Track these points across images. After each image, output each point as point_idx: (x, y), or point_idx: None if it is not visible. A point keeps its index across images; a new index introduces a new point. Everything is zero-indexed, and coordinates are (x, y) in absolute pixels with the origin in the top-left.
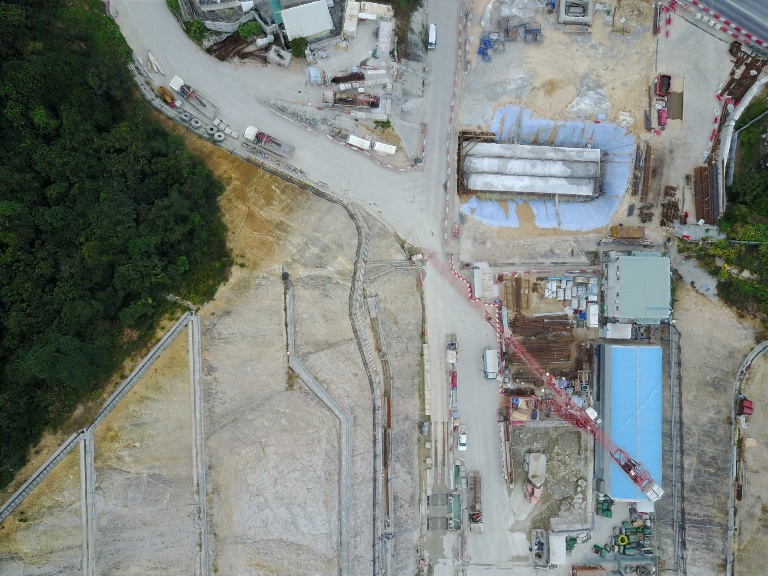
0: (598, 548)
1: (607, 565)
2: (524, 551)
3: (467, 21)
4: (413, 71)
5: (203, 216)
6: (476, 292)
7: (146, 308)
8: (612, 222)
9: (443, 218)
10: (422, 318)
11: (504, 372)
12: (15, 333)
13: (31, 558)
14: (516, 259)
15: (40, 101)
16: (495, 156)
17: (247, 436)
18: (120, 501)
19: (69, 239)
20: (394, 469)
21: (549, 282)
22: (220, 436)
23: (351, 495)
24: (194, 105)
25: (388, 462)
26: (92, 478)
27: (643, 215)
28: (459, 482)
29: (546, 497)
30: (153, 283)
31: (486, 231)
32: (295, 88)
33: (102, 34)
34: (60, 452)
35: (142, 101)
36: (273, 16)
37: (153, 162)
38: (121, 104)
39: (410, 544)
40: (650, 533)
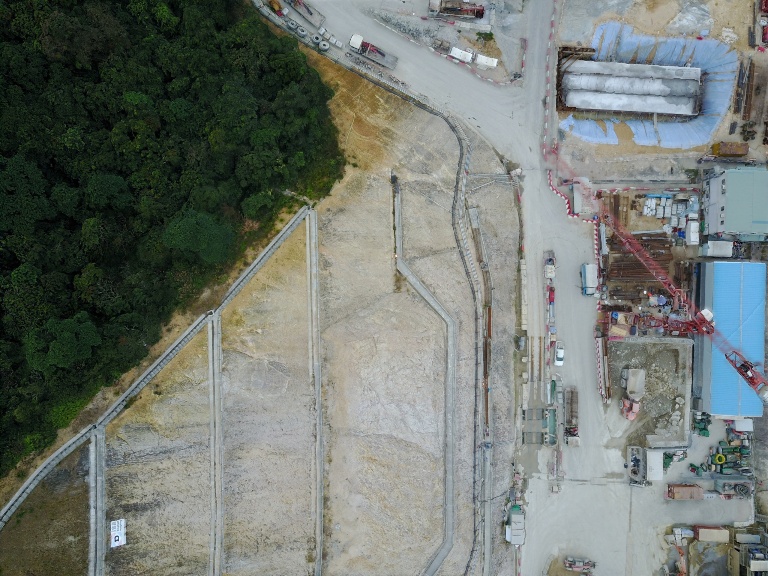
0: (694, 467)
1: (703, 484)
2: (619, 468)
3: None
4: None
5: (316, 116)
6: (575, 207)
7: (266, 199)
8: (714, 140)
9: (541, 134)
10: (519, 234)
11: (602, 289)
12: (145, 216)
13: (165, 430)
14: (615, 176)
15: None
16: (594, 73)
17: (360, 331)
18: (244, 384)
19: (192, 131)
20: (493, 379)
21: (648, 199)
22: (335, 330)
23: (456, 398)
24: (301, 13)
25: (488, 371)
26: (220, 358)
27: (745, 133)
28: (555, 397)
29: (642, 415)
30: (274, 174)
31: (585, 148)
32: None
33: None
34: (190, 331)
35: (251, 7)
36: None
37: (271, 58)
38: (232, 9)
39: (506, 456)
40: (748, 453)
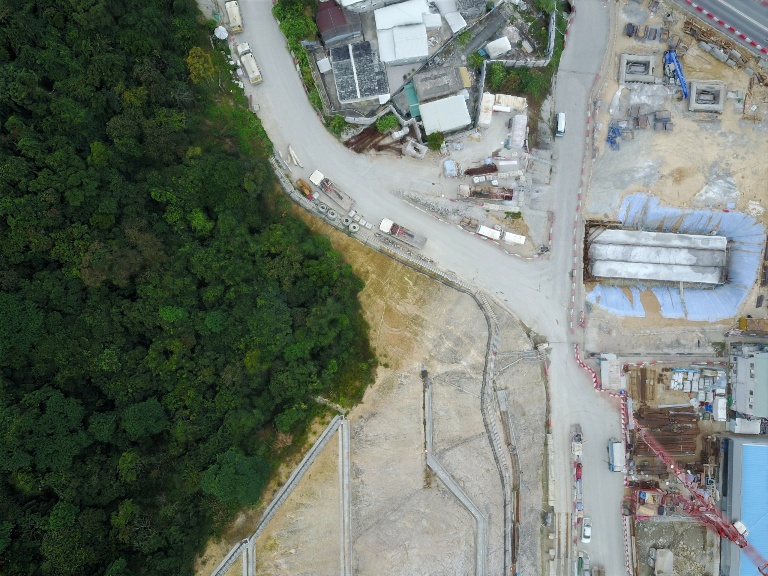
0: None
1: None
2: None
3: (595, 108)
4: (542, 160)
5: (348, 316)
6: (603, 384)
7: (300, 414)
8: (741, 314)
9: (568, 307)
10: (546, 407)
11: (629, 464)
12: (181, 441)
13: None
14: (641, 349)
15: (195, 203)
16: (620, 244)
17: (392, 539)
18: None
19: (227, 344)
20: (521, 563)
21: (675, 374)
22: (366, 539)
23: None
24: (331, 197)
25: (516, 556)
26: None
27: None
28: (582, 574)
29: None
30: (308, 390)
31: (611, 320)
32: (429, 180)
33: (246, 129)
34: (225, 562)
35: (283, 195)
36: (409, 108)
37: (305, 265)
38: (264, 199)
39: None
40: None
